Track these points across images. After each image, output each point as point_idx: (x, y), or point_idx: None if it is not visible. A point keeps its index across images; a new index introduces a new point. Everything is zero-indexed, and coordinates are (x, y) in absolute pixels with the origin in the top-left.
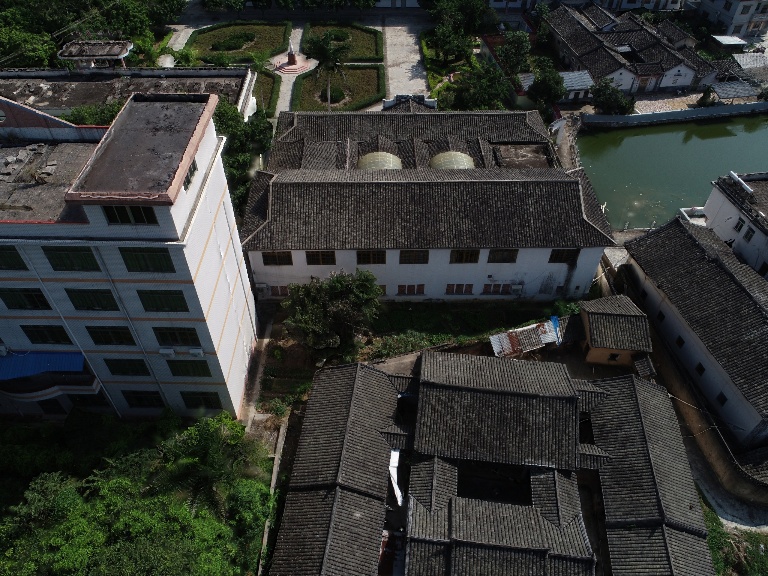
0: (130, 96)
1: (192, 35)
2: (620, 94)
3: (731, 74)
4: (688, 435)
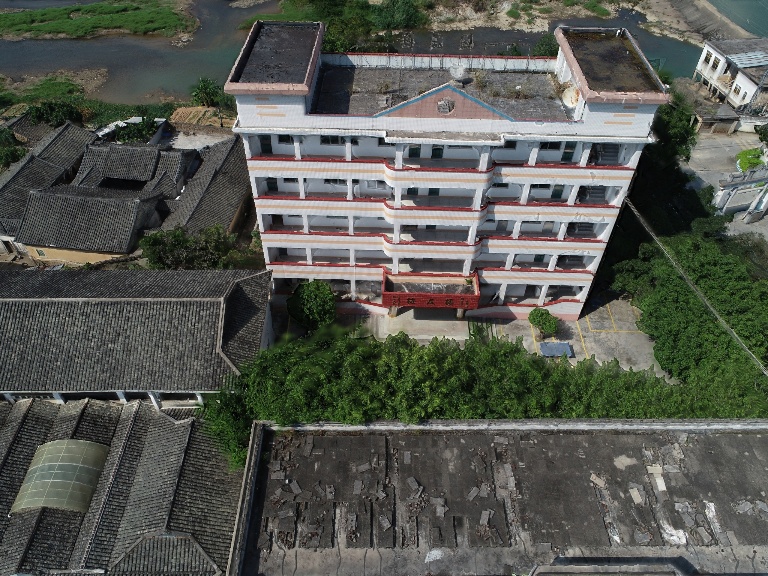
0: (306, 81)
1: None
2: None
3: None
4: None
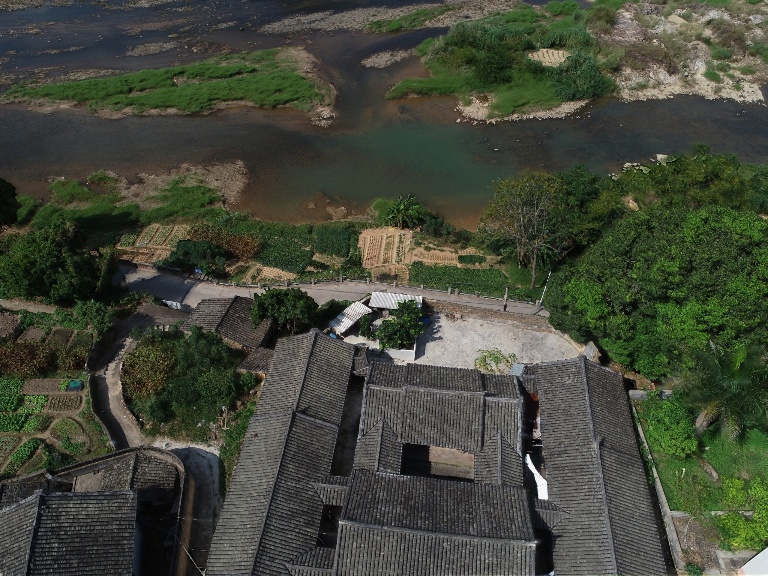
0: None
1: None
2: None
3: None
4: (194, 551)
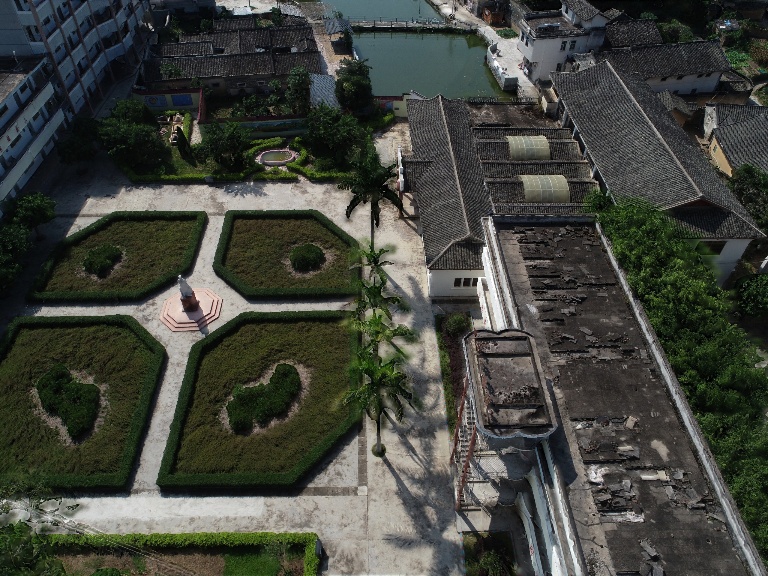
0: None
1: (3, 481)
2: (362, 64)
3: (306, 23)
4: None
